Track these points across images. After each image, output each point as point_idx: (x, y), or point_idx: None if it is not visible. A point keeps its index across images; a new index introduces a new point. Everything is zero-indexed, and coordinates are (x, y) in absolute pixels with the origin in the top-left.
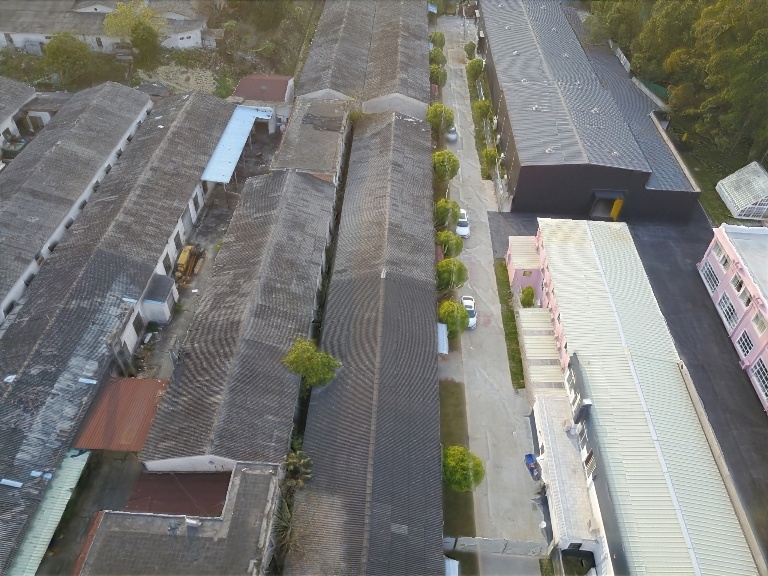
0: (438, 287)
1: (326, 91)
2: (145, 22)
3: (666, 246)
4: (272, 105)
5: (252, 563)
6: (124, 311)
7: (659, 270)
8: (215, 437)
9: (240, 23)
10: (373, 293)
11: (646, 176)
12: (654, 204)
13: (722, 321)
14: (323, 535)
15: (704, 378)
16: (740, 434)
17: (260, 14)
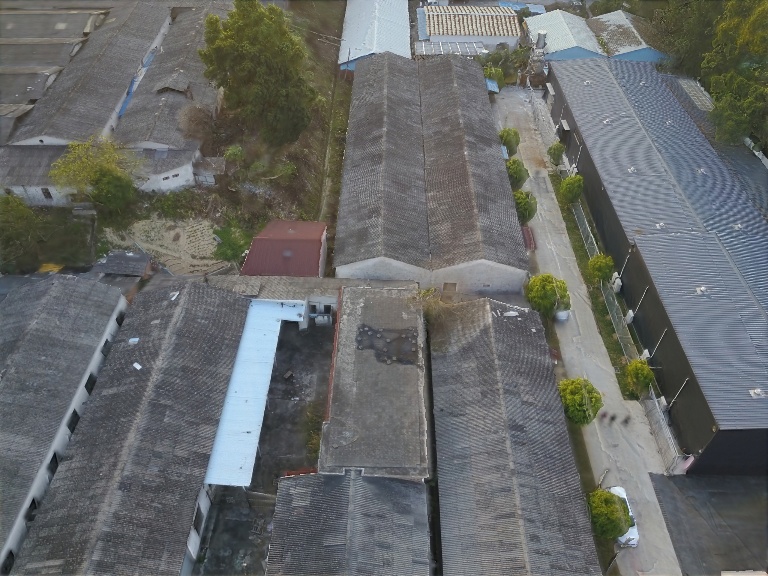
0: None
1: (379, 259)
2: (110, 170)
3: None
4: (303, 294)
5: None
6: None
7: None
8: None
9: (245, 136)
10: None
11: None
12: None
13: None
14: None
15: None
16: None
17: (274, 129)
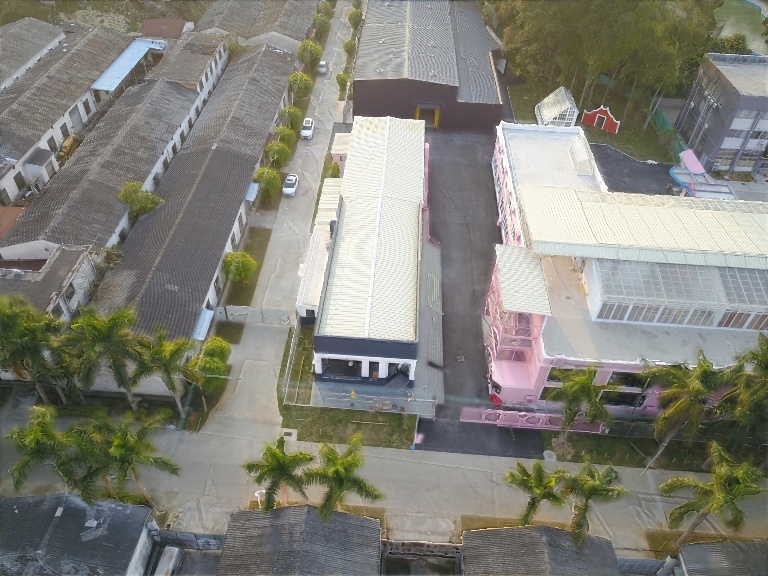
0: (267, 165)
1: (215, 30)
2: None
3: (472, 148)
4: (166, 39)
5: (54, 293)
6: (5, 166)
7: (459, 163)
8: (49, 231)
9: None
10: (202, 159)
11: (455, 90)
12: (467, 116)
13: (496, 196)
14: (117, 290)
15: (465, 231)
16: (478, 265)
17: None
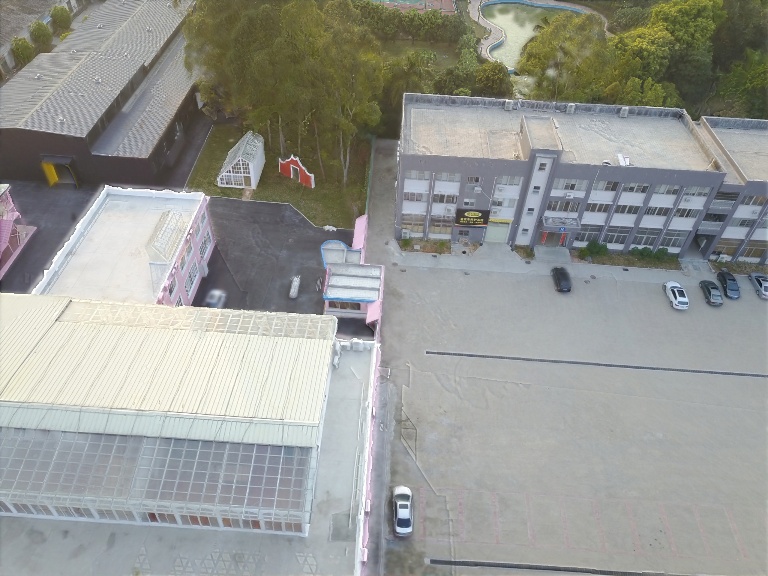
0: None
1: None
2: None
3: None
4: None
5: None
6: None
7: None
8: None
9: None
10: None
11: (81, 141)
12: (111, 170)
13: None
14: None
15: None
16: None
17: None
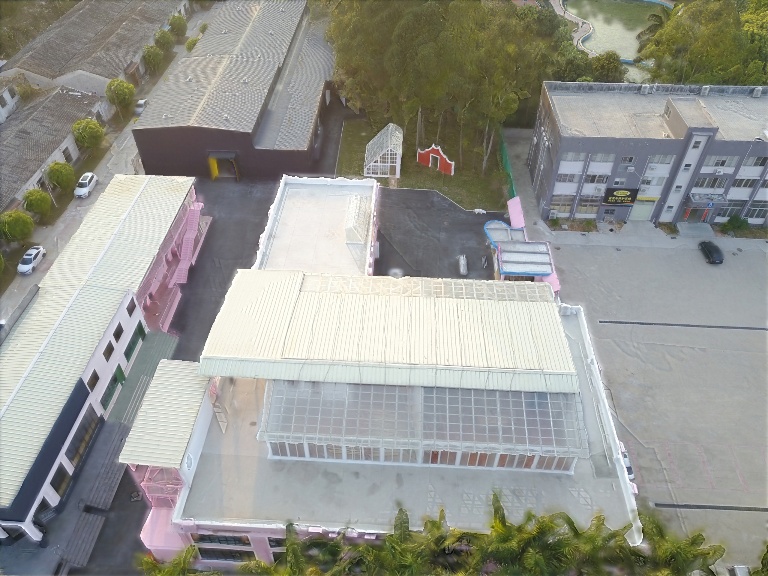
0: (2, 238)
1: (16, 70)
2: None
3: (272, 201)
4: None
5: None
6: None
7: (248, 222)
8: None
9: None
10: None
11: (248, 136)
12: (270, 163)
13: None
14: None
15: None
16: None
17: None
